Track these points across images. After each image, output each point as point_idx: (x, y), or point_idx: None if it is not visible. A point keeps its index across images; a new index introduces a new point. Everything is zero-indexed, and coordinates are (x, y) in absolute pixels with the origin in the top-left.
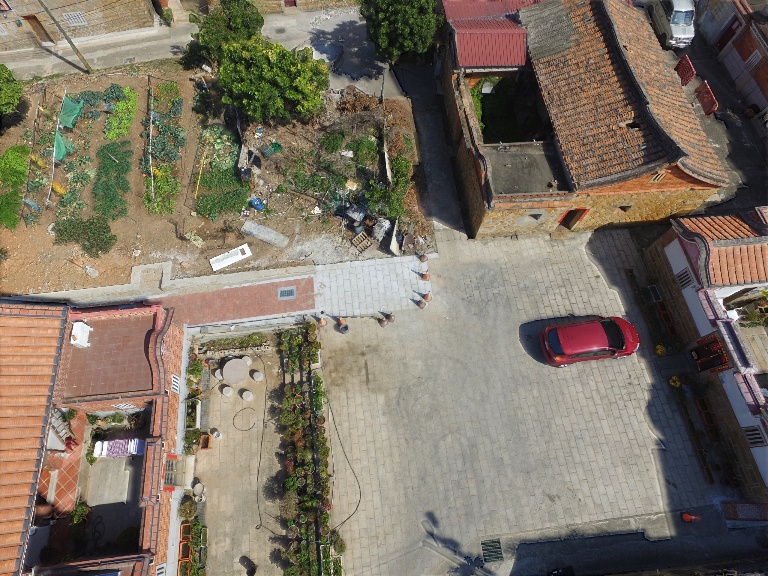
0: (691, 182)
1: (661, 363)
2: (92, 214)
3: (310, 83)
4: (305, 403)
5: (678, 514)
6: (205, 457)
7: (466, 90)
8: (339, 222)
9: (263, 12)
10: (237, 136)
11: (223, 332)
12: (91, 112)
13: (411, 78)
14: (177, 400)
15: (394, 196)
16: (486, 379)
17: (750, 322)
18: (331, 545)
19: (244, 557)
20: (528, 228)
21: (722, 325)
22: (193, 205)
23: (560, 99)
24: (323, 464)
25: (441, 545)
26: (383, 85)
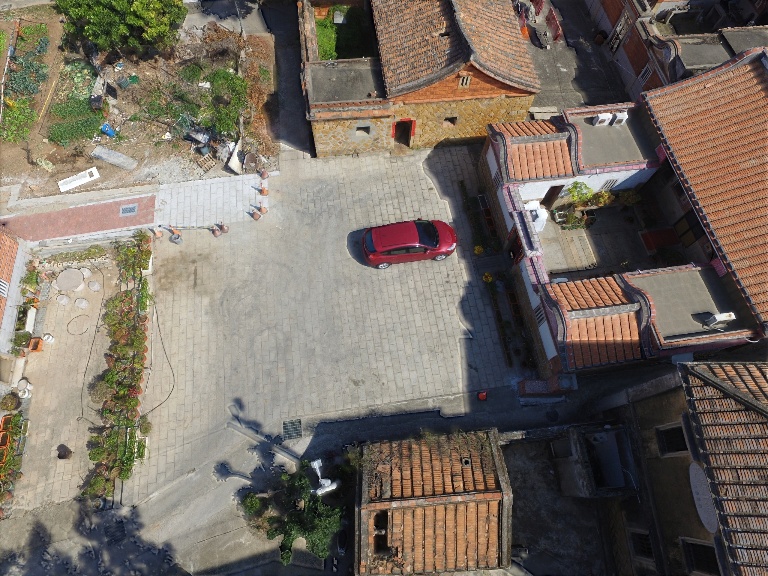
0: (501, 88)
1: (480, 263)
2: None
3: (164, 16)
4: (133, 306)
5: (475, 394)
6: (36, 359)
7: (309, 16)
8: (189, 146)
9: None
10: None
11: (61, 245)
12: None
13: (277, 16)
14: (3, 302)
15: (224, 111)
16: (309, 281)
17: (571, 225)
18: (138, 428)
19: (62, 445)
20: (365, 145)
21: (516, 215)
22: (47, 133)
23: (387, 17)
24: (139, 357)
25: (244, 426)
26: (249, 23)
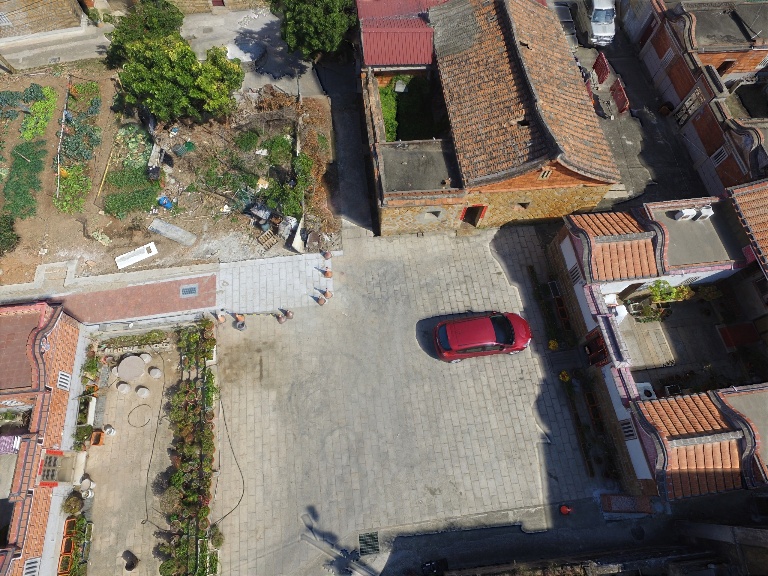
0: (581, 179)
1: (554, 358)
2: (1, 213)
3: (222, 82)
4: (198, 399)
5: (557, 507)
6: (97, 453)
7: (374, 89)
8: (248, 220)
9: (191, 12)
10: (151, 135)
11: (121, 330)
12: (8, 112)
13: (332, 77)
14: (66, 397)
15: (291, 194)
16: (379, 375)
17: (646, 317)
18: (209, 539)
19: (127, 552)
20: (431, 225)
21: (602, 320)
22: (102, 204)
23: (459, 97)
24: (208, 459)
25: (319, 538)
26: (304, 84)
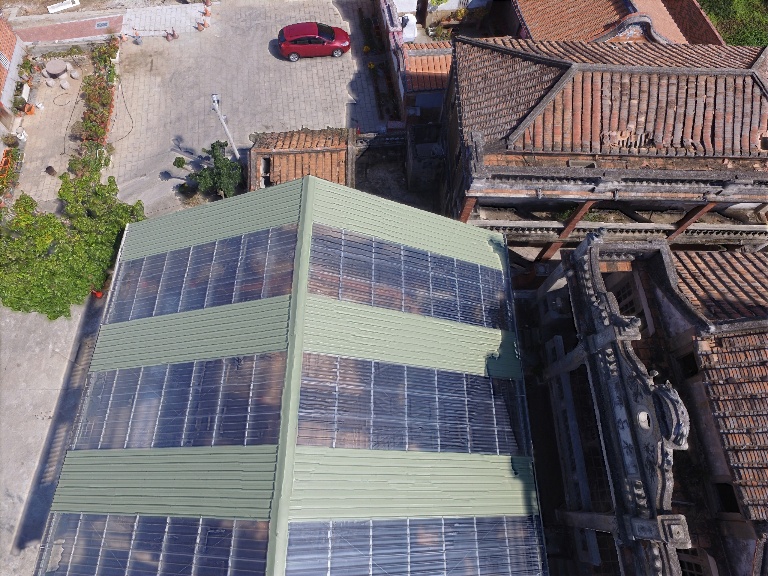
0: None
1: (368, 59)
2: None
3: None
4: None
5: None
6: (30, 119)
7: None
8: None
9: None
10: None
11: (49, 44)
12: None
13: None
14: (5, 72)
15: None
16: (238, 68)
17: None
18: (105, 149)
19: None
20: None
21: (386, 7)
22: None
23: None
24: (107, 108)
25: (183, 150)
26: None
